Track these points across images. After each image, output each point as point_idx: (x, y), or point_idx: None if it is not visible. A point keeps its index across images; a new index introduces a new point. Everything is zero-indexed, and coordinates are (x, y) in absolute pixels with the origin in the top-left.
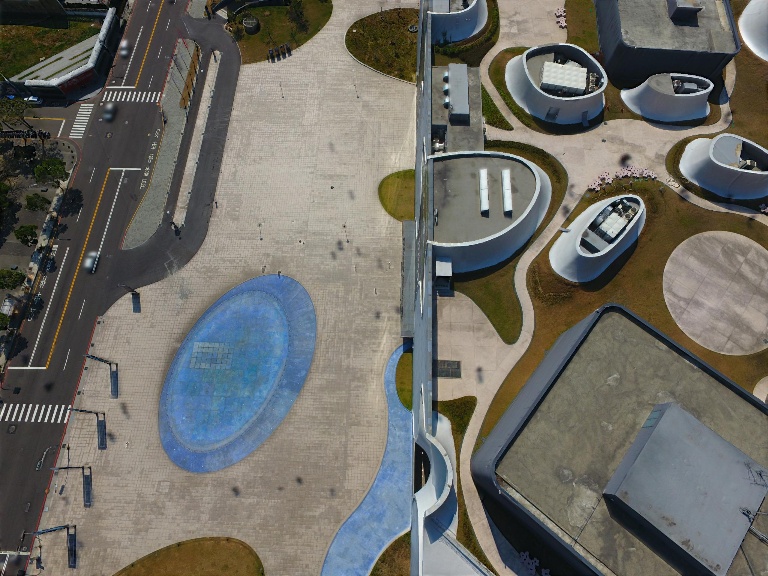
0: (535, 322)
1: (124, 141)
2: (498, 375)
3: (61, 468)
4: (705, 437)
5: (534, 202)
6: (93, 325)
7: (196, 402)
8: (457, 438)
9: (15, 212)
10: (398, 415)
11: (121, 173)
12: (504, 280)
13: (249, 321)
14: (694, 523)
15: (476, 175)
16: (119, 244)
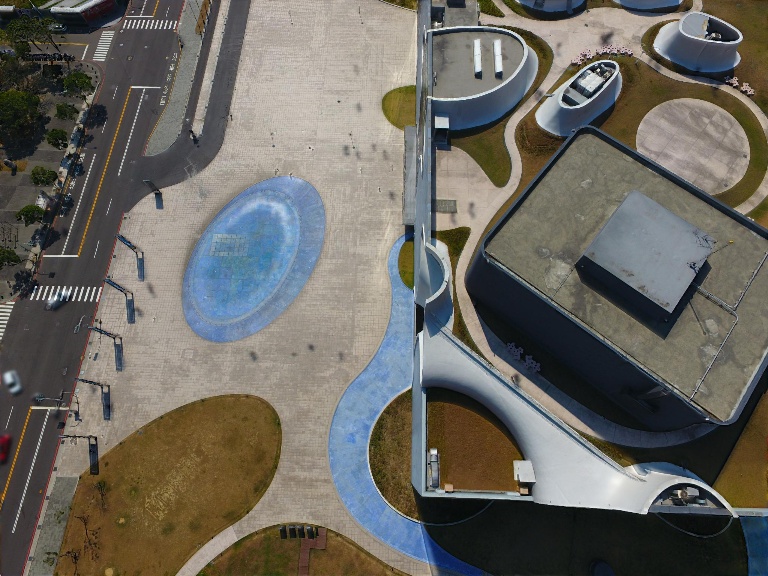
0: (522, 170)
1: (144, 63)
2: (489, 211)
3: (97, 328)
4: (661, 214)
5: (522, 66)
6: (120, 220)
7: (216, 284)
8: (453, 259)
9: (45, 124)
10: (401, 293)
11: (142, 91)
12: (495, 136)
13: (263, 216)
14: (649, 274)
15: (471, 46)
16: (142, 152)
